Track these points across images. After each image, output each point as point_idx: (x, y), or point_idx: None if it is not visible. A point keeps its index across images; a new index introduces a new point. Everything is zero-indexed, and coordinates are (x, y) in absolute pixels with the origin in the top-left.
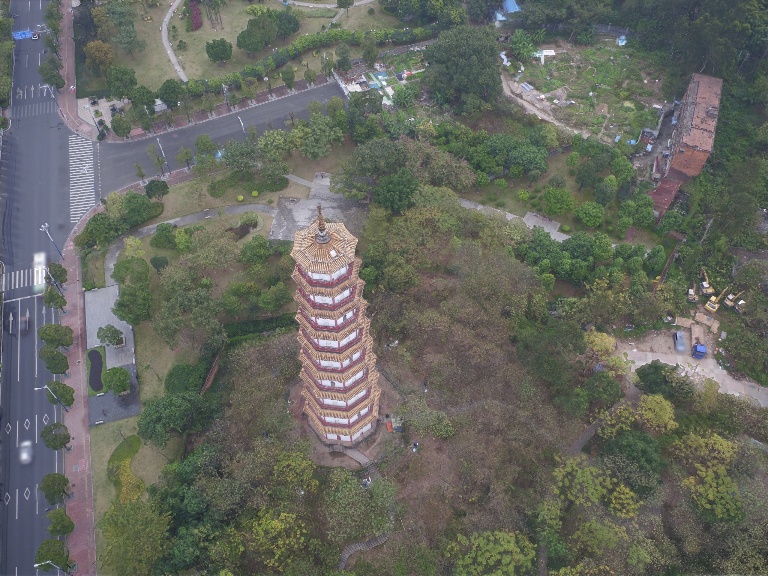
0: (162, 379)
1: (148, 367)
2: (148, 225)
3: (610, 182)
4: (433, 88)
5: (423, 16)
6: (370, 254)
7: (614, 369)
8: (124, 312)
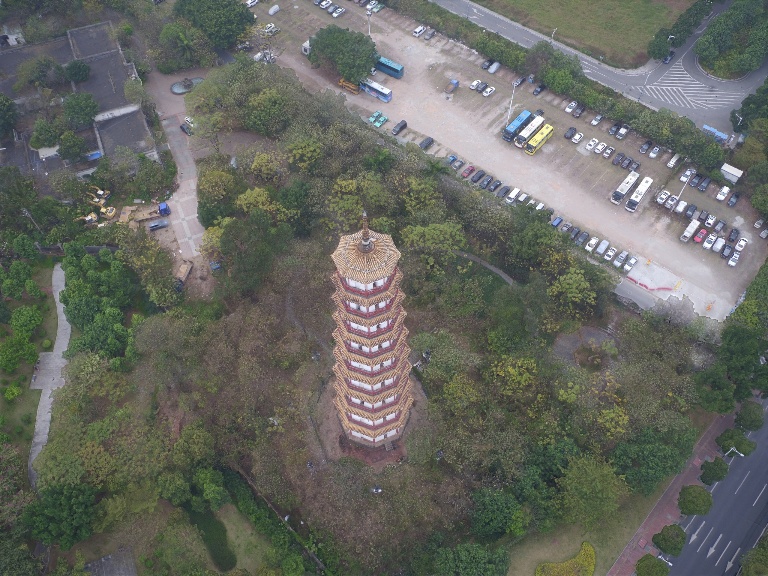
0: None
1: None
2: None
3: None
4: None
5: None
6: (182, 483)
7: None
8: None
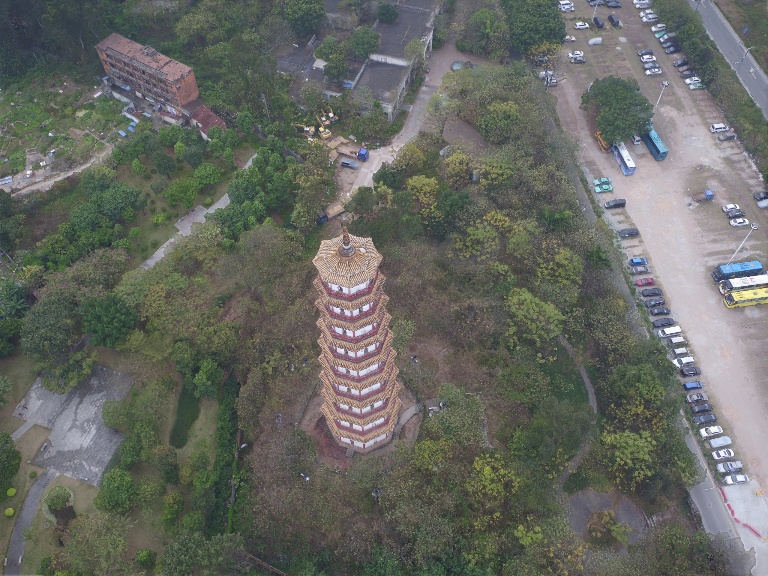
0: None
1: None
2: None
3: (182, 148)
4: None
5: None
6: (188, 358)
7: None
8: None
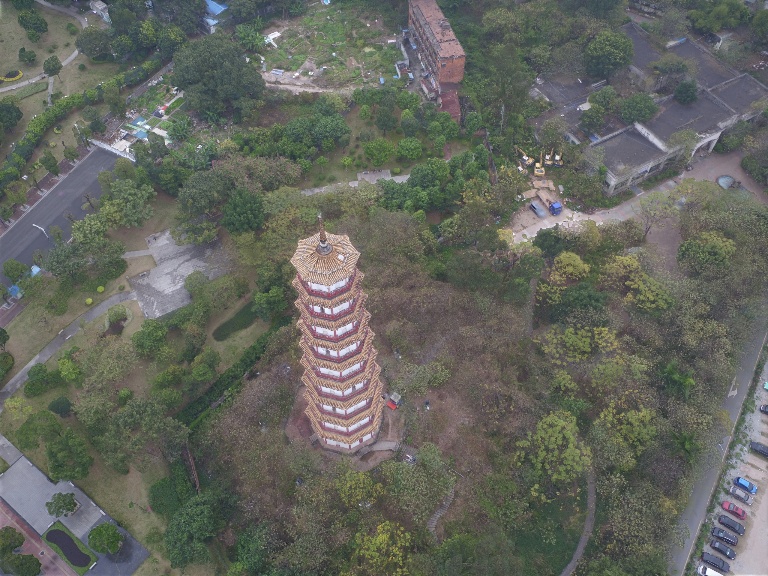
0: (146, 509)
1: (132, 504)
2: (8, 381)
3: (408, 116)
4: (201, 109)
5: (139, 50)
6: (266, 277)
7: (524, 252)
8: (66, 471)
